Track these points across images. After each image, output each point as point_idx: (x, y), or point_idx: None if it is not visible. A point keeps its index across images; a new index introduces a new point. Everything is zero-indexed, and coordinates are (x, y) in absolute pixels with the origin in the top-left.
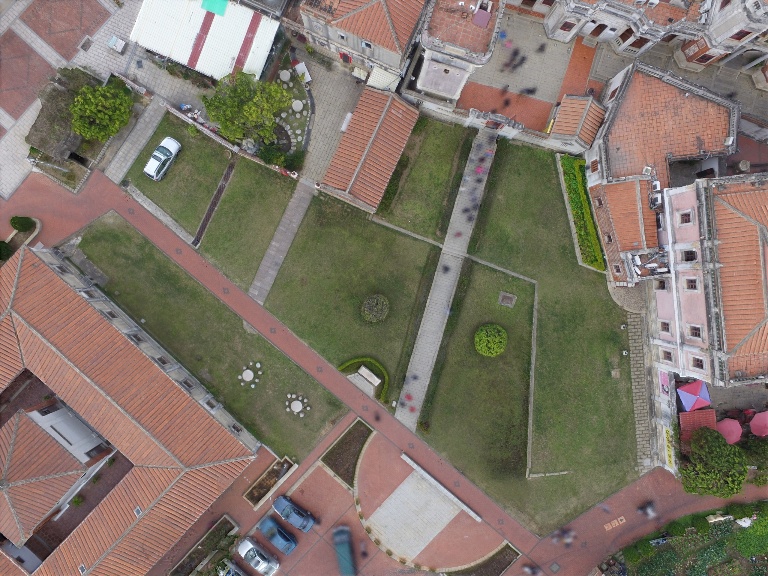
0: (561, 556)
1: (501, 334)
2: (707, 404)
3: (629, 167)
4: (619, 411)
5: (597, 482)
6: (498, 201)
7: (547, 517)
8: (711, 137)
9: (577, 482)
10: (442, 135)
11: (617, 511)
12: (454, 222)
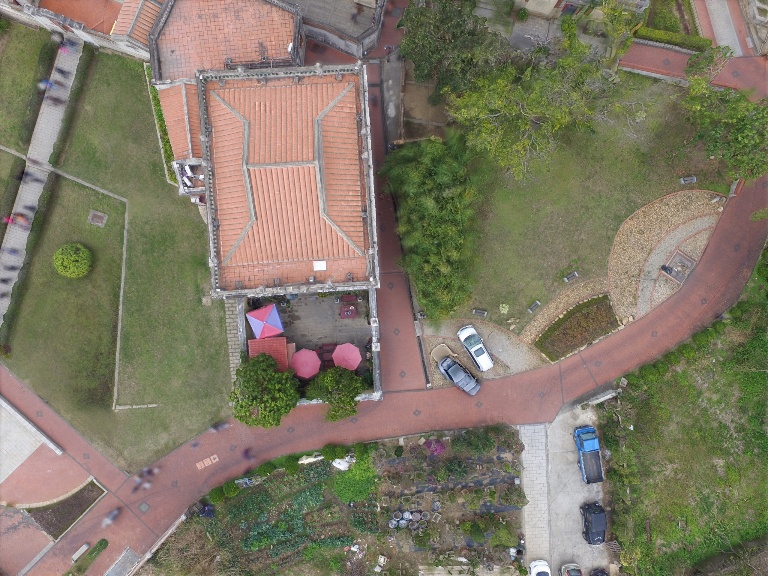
0: (150, 495)
1: (78, 252)
2: (279, 332)
3: (184, 71)
4: (211, 341)
5: (189, 417)
6: (85, 112)
7: (136, 453)
8: (275, 44)
9: (167, 416)
10: (26, 39)
11: (210, 449)
12: (38, 133)
